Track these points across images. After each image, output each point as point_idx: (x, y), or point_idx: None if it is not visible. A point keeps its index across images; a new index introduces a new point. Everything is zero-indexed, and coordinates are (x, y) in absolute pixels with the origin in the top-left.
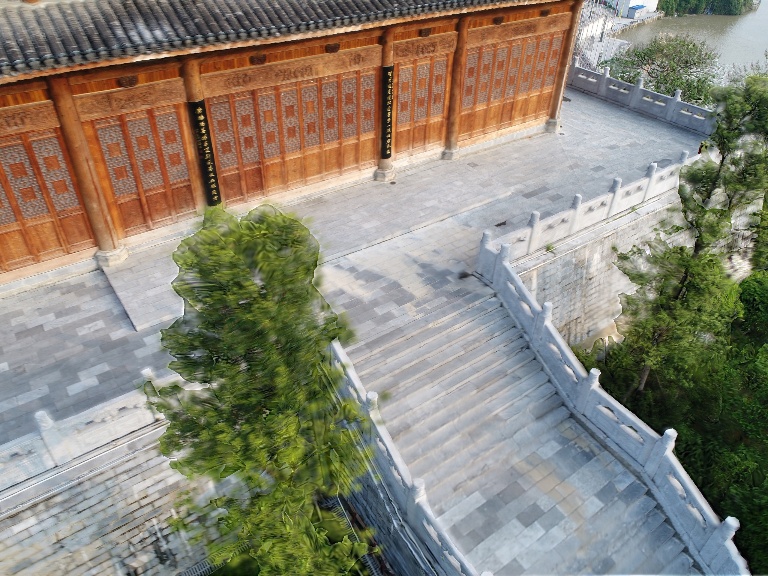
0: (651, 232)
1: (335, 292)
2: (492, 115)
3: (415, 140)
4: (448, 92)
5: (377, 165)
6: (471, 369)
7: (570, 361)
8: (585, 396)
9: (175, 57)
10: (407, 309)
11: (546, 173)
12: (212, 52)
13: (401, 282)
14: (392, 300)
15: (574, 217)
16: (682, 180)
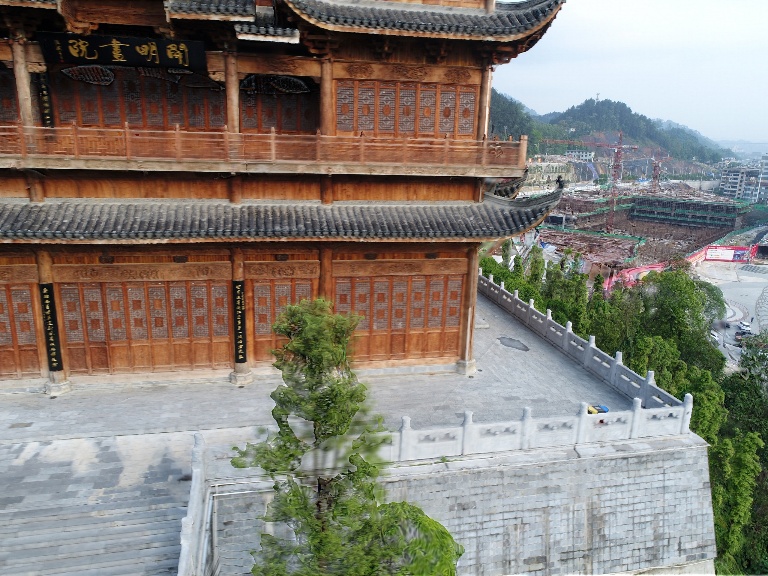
0: (475, 495)
1: (63, 463)
2: (378, 343)
3: None
4: None
5: (234, 368)
6: (95, 572)
7: None
8: None
9: None
10: (94, 493)
11: (403, 408)
12: (24, 244)
13: (126, 469)
14: (95, 482)
15: (336, 447)
16: None
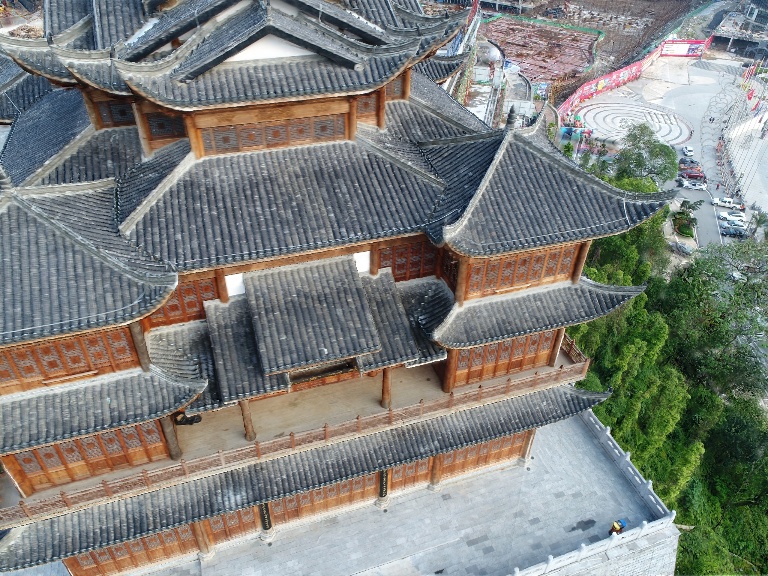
0: None
1: None
2: (469, 462)
3: (406, 483)
4: (432, 460)
5: (377, 497)
6: None
7: None
8: None
9: None
10: None
11: (495, 518)
12: None
13: None
14: None
15: None
16: None
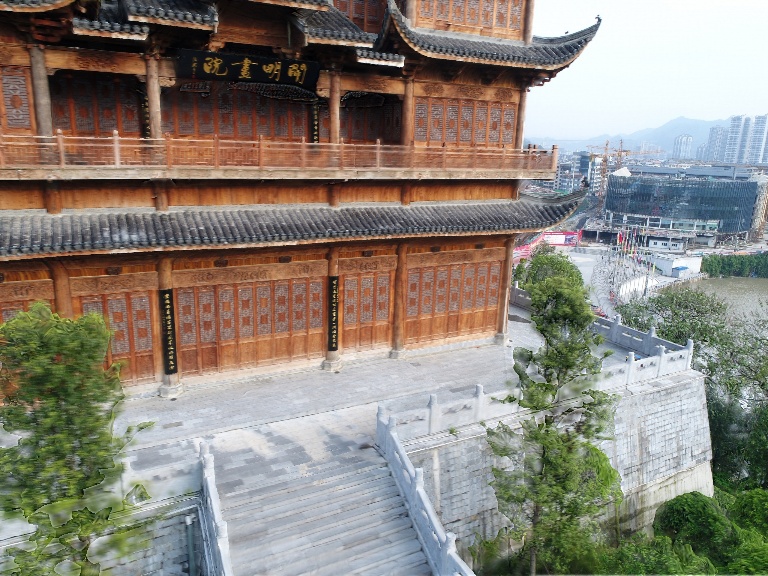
0: None
1: (244, 450)
2: (438, 324)
3: (362, 339)
4: (392, 301)
5: (325, 356)
6: (343, 527)
7: (434, 526)
8: (445, 563)
9: (142, 253)
10: (300, 468)
11: (480, 375)
12: (172, 251)
13: (306, 447)
14: (290, 460)
15: (477, 405)
16: (515, 358)
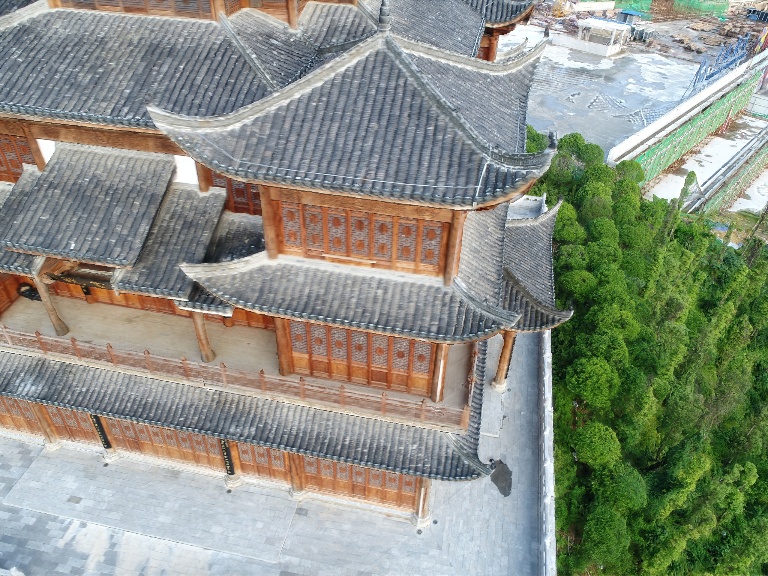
0: None
1: (84, 555)
2: (342, 485)
3: (261, 472)
4: (288, 458)
5: None
6: None
7: None
8: None
9: None
10: None
11: (333, 564)
12: None
13: None
14: None
15: None
16: None
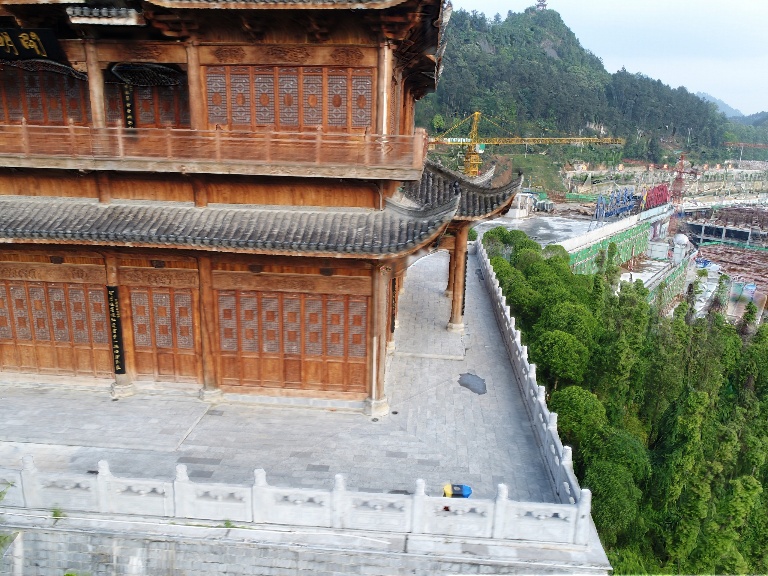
0: (260, 575)
1: None
2: (270, 368)
3: (162, 366)
4: (199, 328)
5: None
6: None
7: None
8: None
9: None
10: None
11: (257, 448)
12: None
13: None
14: None
15: (98, 489)
16: None
